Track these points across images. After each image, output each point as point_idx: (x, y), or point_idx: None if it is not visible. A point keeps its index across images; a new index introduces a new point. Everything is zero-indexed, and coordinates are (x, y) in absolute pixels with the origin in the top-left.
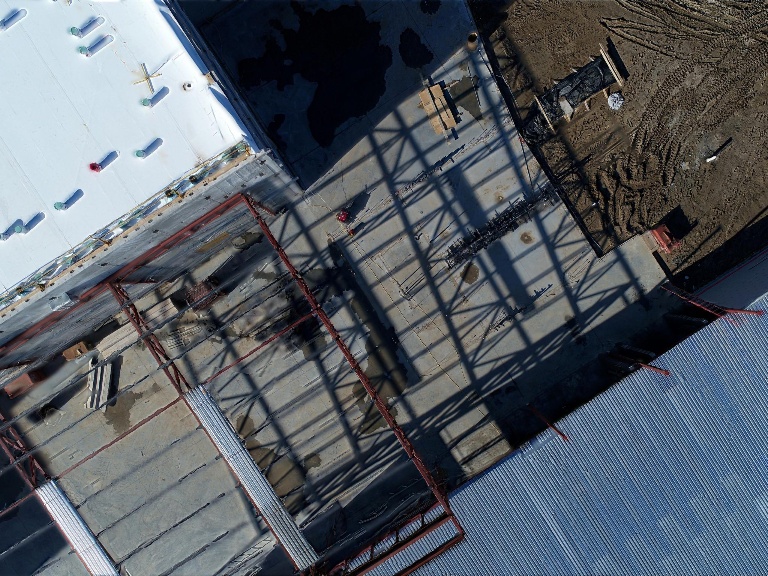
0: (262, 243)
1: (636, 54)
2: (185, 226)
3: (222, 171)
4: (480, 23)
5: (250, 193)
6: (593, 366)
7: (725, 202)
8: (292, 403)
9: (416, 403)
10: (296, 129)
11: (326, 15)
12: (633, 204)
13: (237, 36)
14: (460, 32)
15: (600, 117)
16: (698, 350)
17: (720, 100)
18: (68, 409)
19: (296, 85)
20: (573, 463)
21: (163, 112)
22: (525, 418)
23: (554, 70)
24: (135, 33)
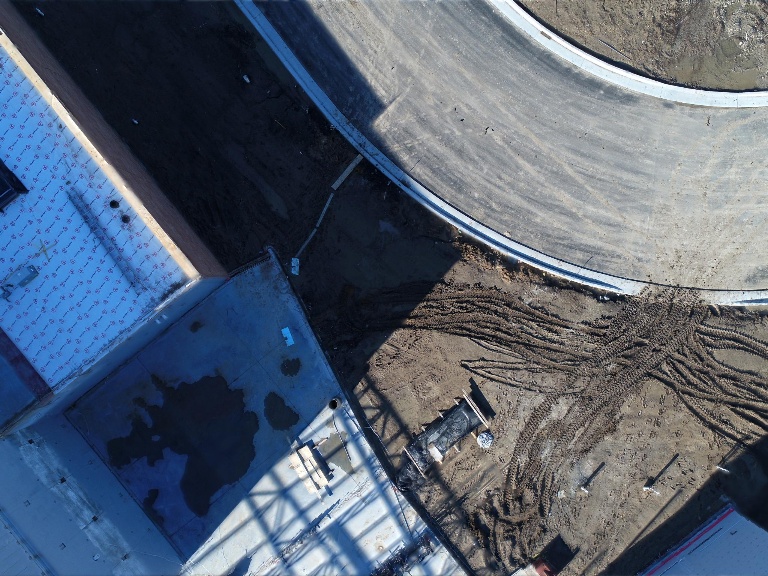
0: None
1: (500, 393)
2: None
3: None
4: (343, 377)
5: None
6: None
7: (604, 526)
8: None
9: None
10: (171, 502)
11: (188, 388)
12: (513, 537)
13: (102, 418)
14: (323, 390)
15: (471, 457)
16: None
17: (588, 427)
18: None
19: (166, 459)
20: None
21: None
22: None
23: (421, 415)
24: None
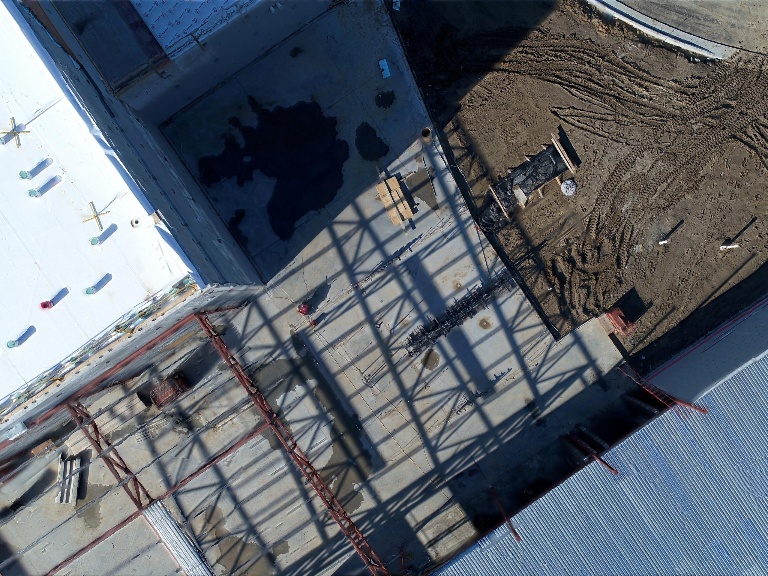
0: (226, 335)
1: (587, 141)
2: (140, 347)
3: (170, 306)
4: (434, 115)
5: (204, 309)
6: (554, 447)
7: (679, 283)
8: (259, 491)
9: (381, 488)
10: (256, 223)
11: (283, 111)
12: (589, 287)
13: (196, 134)
14: (414, 125)
15: (554, 203)
16: (650, 442)
17: (671, 184)
18: (39, 503)
19: (255, 180)
20: (531, 556)
21: (112, 248)
22: (489, 500)
23: (508, 159)
24: (83, 173)
